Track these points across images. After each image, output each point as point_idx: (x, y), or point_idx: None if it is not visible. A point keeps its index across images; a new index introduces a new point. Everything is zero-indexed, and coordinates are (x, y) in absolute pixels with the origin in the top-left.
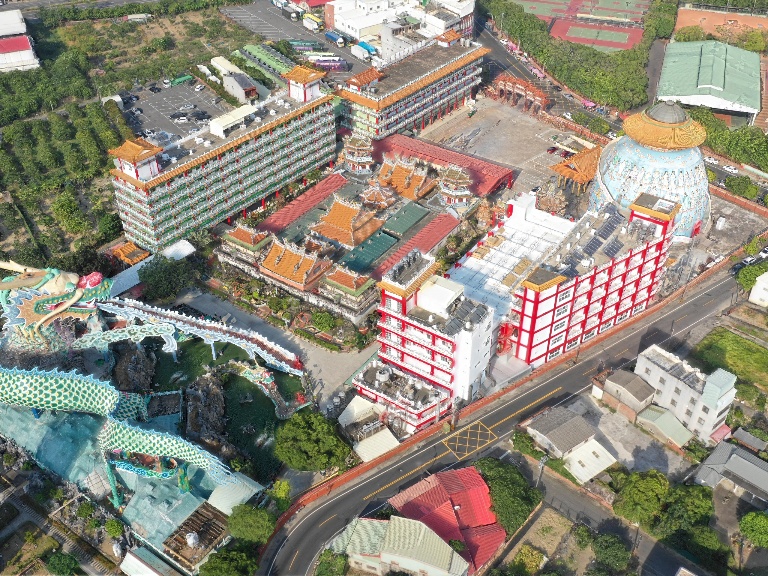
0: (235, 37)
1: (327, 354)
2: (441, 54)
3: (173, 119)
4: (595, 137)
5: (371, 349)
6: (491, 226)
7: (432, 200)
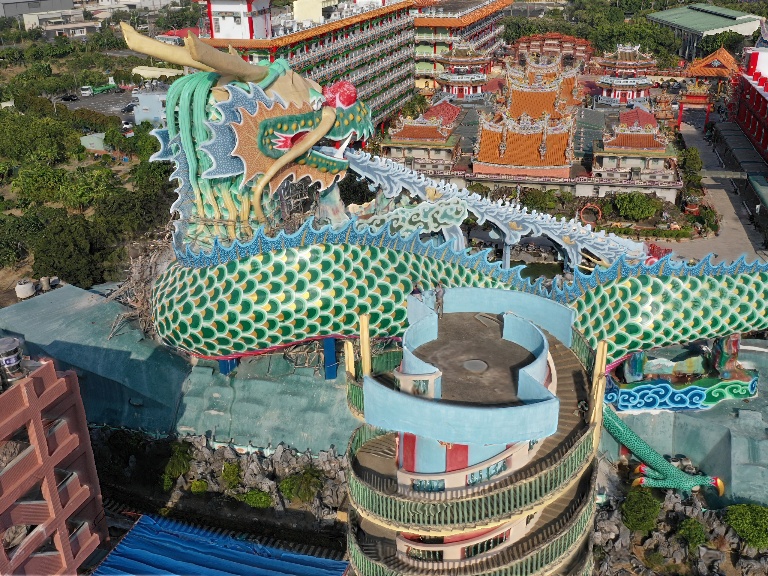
0: (141, 61)
1: (676, 244)
2: (468, 1)
3: (127, 113)
4: (665, 74)
5: (726, 230)
6: (677, 127)
7: (595, 105)
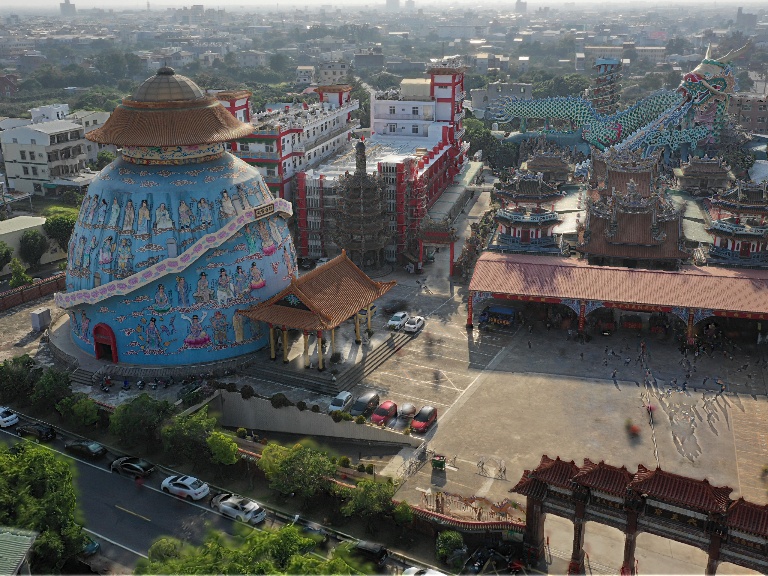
0: None
1: None
2: None
3: None
4: None
5: None
6: None
7: None
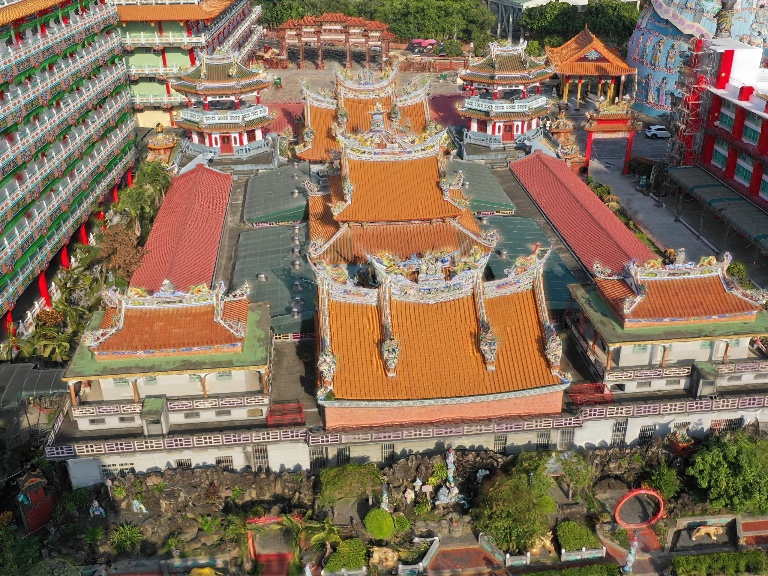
0: None
1: None
2: None
3: None
4: None
5: None
6: (584, 170)
7: None
